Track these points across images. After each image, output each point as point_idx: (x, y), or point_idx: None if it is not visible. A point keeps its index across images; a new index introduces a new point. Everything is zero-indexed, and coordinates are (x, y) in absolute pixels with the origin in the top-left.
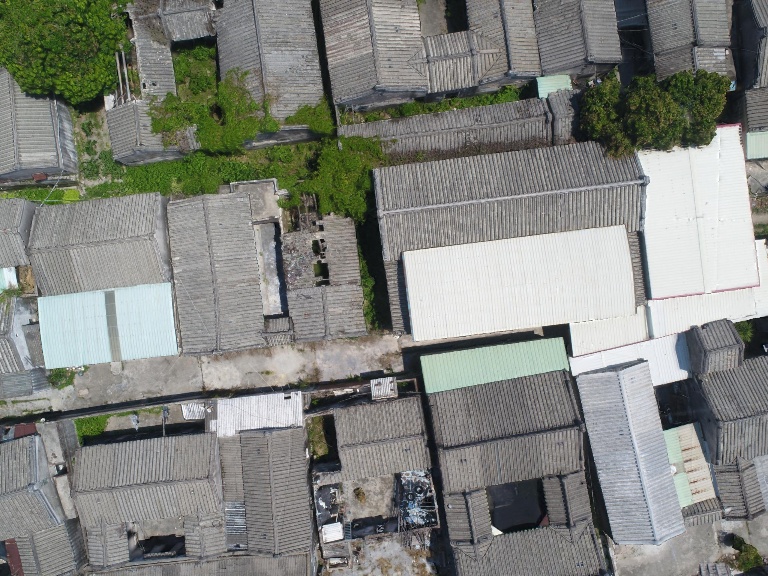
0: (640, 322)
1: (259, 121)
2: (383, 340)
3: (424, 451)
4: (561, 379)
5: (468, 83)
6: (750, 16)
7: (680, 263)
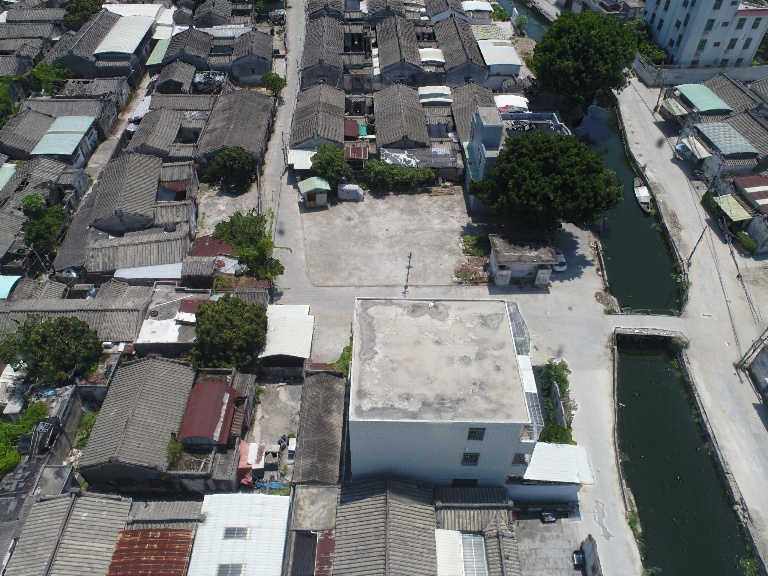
0: None
1: (3, 84)
2: None
3: None
4: (174, 37)
5: (38, 51)
6: (67, 3)
7: (144, 13)
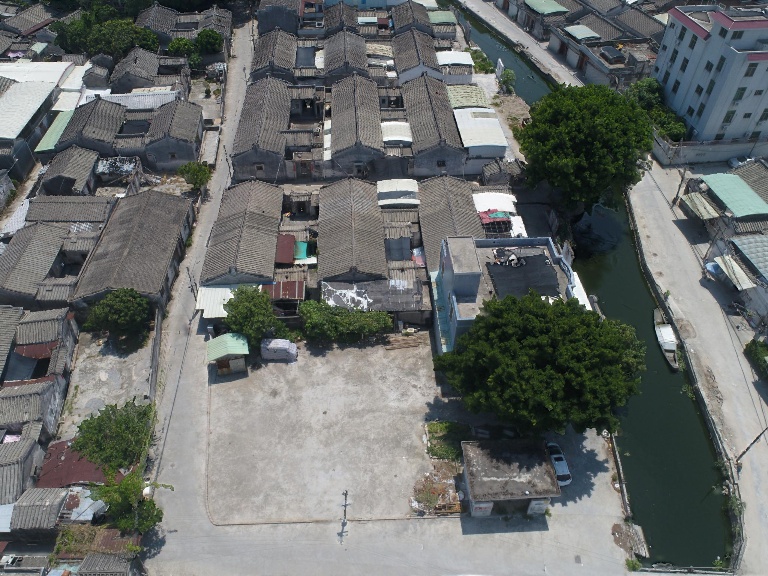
0: (71, 94)
1: None
2: (27, 186)
3: (86, 151)
4: None
5: None
6: None
7: (46, 76)
